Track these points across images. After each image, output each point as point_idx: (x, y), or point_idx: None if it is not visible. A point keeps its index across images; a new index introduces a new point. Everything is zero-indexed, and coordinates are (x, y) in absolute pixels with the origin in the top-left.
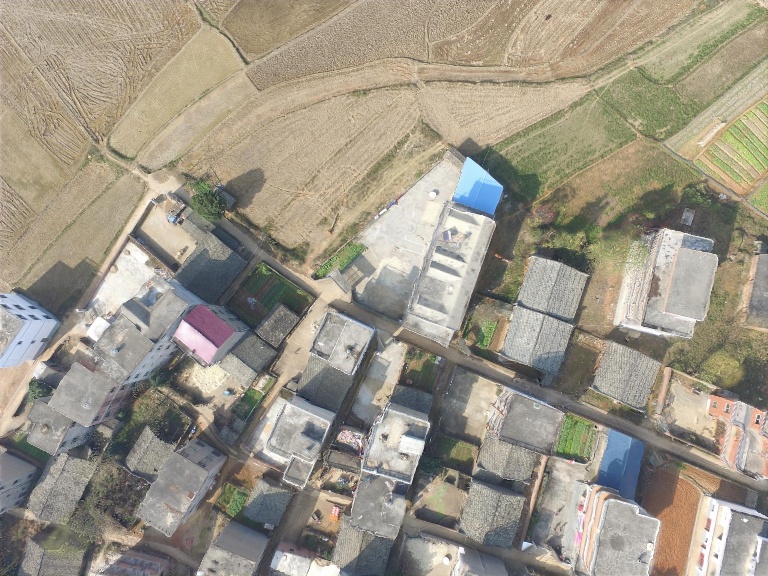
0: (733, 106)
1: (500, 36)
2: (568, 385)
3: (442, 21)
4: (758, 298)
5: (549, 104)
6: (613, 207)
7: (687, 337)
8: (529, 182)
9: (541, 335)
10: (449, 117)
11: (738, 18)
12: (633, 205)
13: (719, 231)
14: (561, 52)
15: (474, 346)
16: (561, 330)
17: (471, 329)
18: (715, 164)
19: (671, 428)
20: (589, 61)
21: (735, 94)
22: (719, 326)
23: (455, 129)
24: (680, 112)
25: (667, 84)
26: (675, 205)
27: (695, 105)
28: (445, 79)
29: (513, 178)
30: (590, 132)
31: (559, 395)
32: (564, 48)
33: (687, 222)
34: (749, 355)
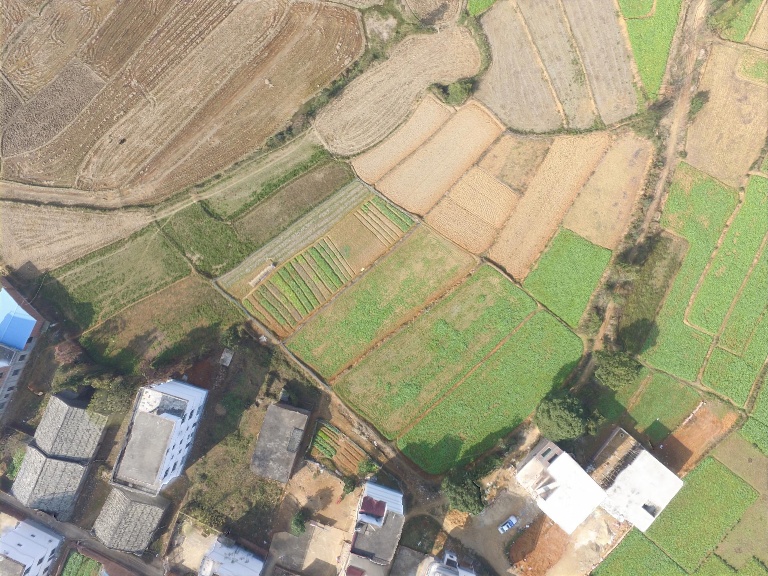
0: (285, 248)
1: (74, 157)
2: (89, 520)
3: (17, 136)
4: (261, 448)
5: (112, 232)
6: (161, 342)
7: (152, 496)
8: (83, 310)
9: (42, 478)
10: (11, 238)
11: (303, 159)
12: (180, 341)
13: (255, 373)
14: (131, 178)
15: (4, 476)
16: (69, 471)
17: (3, 459)
18: (262, 305)
19: (178, 568)
20: (158, 190)
21: (289, 236)
22: (239, 468)
23: (16, 251)
24: (236, 250)
25: (226, 221)
26: (215, 345)
27: (250, 244)
28: (13, 197)
29: (68, 305)
30: (148, 264)
31: (78, 530)
32: (135, 175)
33: (225, 362)
34: (260, 499)
